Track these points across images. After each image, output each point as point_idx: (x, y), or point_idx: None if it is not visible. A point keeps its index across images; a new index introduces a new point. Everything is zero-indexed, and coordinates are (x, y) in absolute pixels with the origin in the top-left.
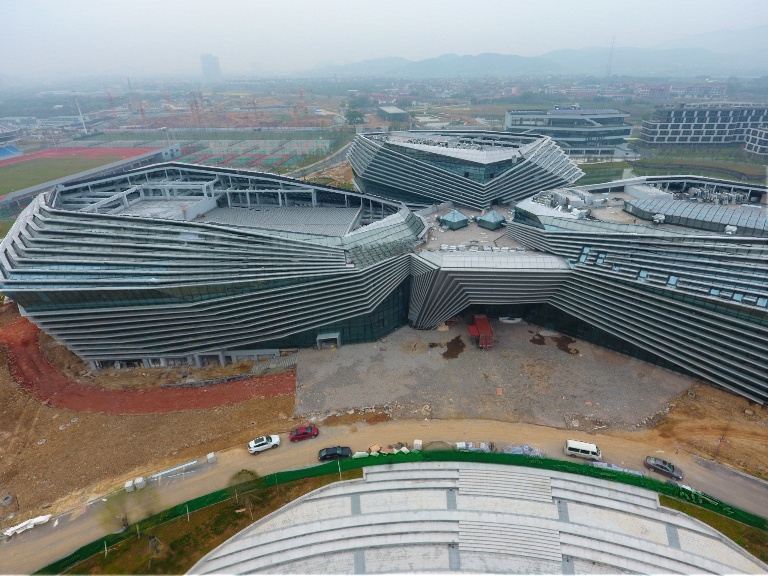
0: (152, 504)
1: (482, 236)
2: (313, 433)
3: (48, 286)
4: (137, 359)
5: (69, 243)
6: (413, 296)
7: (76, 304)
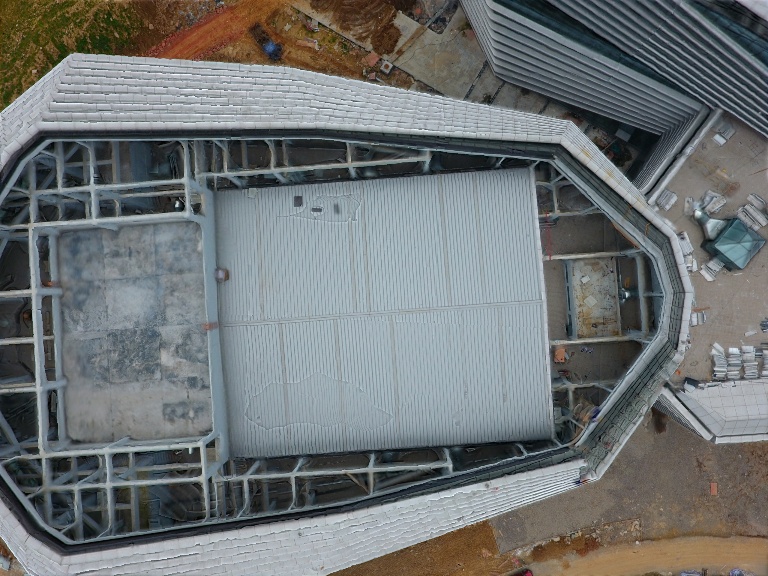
0: None
1: None
2: None
3: None
4: None
5: None
6: None
7: None
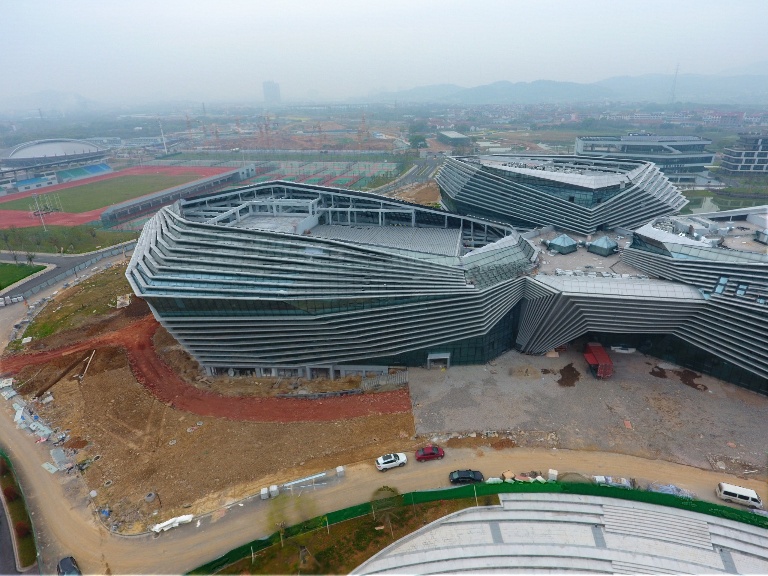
0: (288, 513)
1: (596, 262)
2: (440, 454)
3: (185, 293)
4: (251, 368)
5: (204, 253)
6: (525, 320)
7: (206, 312)
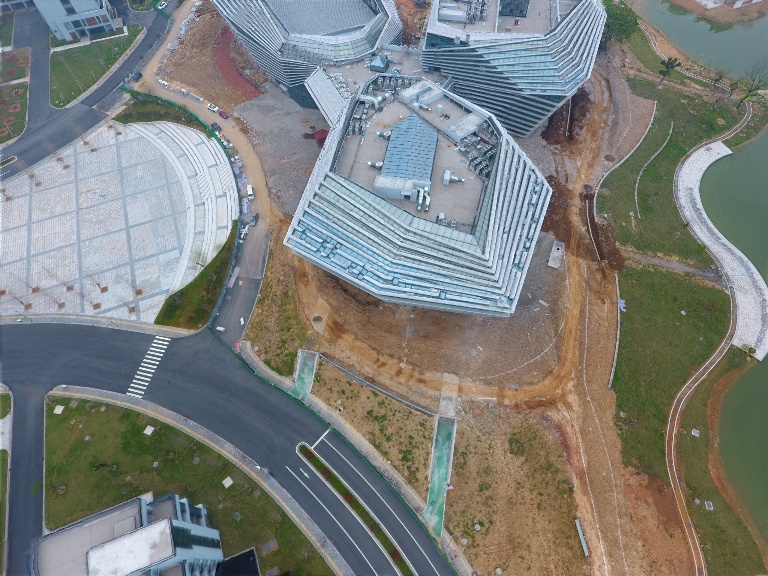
0: (180, 100)
1: None
2: (224, 117)
3: None
4: None
5: None
6: None
7: None
